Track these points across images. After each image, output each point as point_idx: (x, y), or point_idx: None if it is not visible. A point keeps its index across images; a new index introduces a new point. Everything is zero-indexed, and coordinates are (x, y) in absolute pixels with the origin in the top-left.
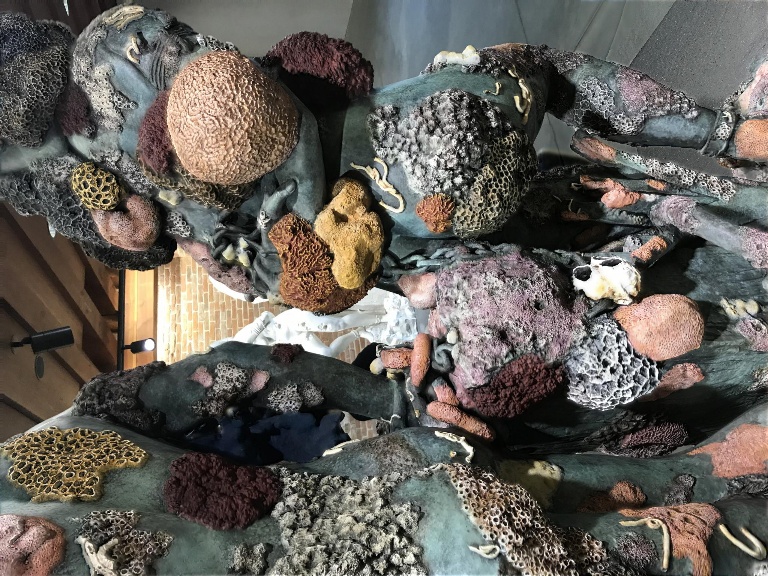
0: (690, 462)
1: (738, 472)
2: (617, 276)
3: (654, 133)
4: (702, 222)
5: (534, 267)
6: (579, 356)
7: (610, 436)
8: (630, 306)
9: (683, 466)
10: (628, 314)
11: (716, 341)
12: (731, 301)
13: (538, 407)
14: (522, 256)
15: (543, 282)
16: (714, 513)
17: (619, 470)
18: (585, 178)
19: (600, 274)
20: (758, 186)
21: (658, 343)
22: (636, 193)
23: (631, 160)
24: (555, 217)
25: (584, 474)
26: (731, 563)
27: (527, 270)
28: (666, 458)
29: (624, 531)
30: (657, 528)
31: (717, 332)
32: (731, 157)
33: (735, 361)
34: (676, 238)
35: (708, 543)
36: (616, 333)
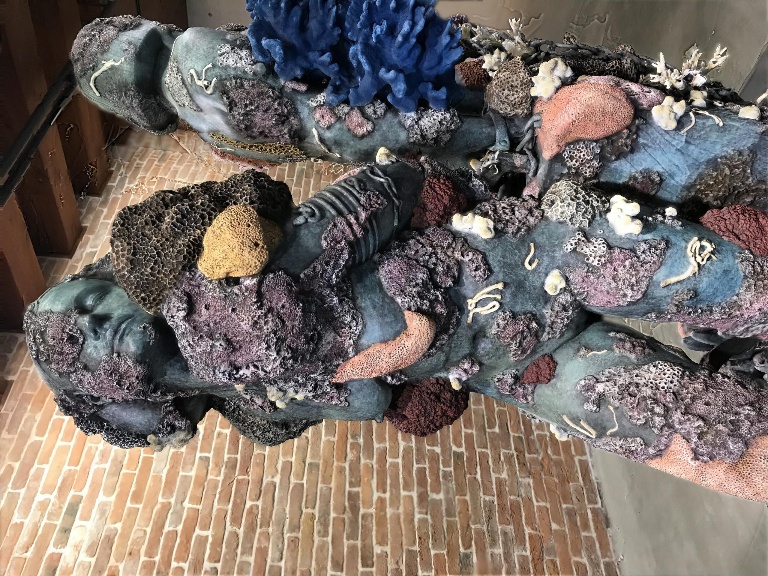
0: None
1: None
2: None
3: None
4: None
5: None
6: None
7: None
8: None
9: None
10: None
11: None
12: None
13: None
14: None
15: None
16: None
17: None
18: None
19: None
20: None
21: None
22: None
23: None
24: None
25: None
26: None
27: None
28: None
29: None
30: None
31: None
32: None
33: None
34: None
35: None
36: None
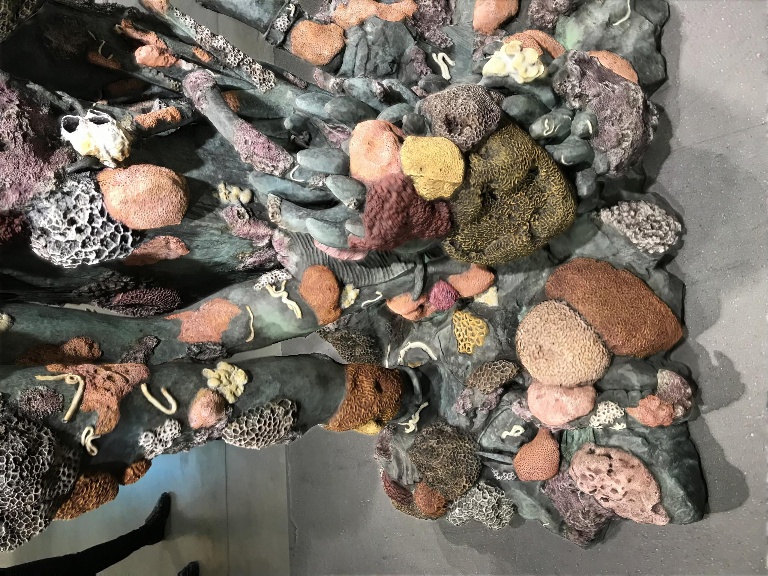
0: (163, 325)
1: (199, 339)
2: (101, 136)
3: (222, 1)
4: (210, 104)
5: (13, 102)
6: (44, 209)
7: (99, 292)
8: (115, 170)
9: (154, 328)
10: (110, 177)
11: (198, 221)
12: (229, 187)
13: (2, 254)
14: (8, 87)
15: (13, 121)
16: (142, 373)
17: (82, 326)
18: (127, 23)
19: (88, 129)
20: (296, 86)
21: (133, 212)
22: (173, 56)
23: (182, 20)
24: (84, 55)
25: (38, 326)
26: (139, 417)
27: (1, 103)
28: (142, 319)
29: (35, 385)
30: (74, 384)
31: (203, 213)
32: (289, 51)
33: (220, 242)
34: (196, 114)
35: (122, 399)
36: (91, 194)
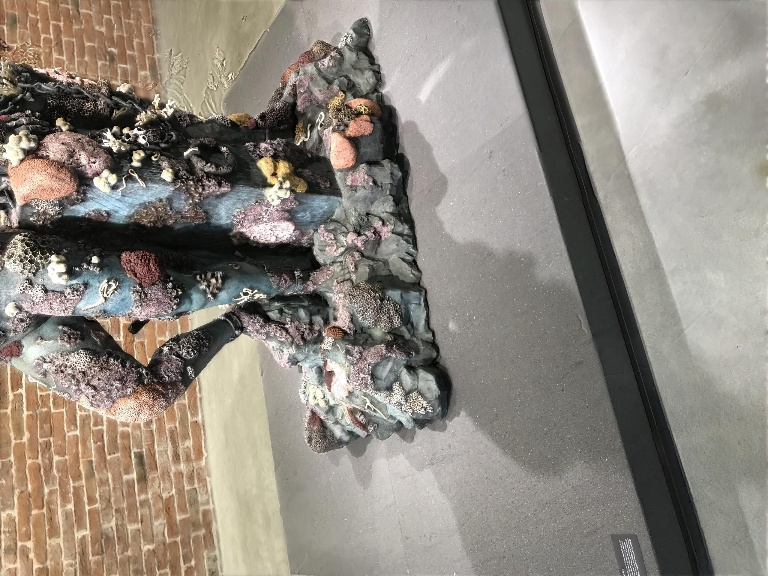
0: None
1: None
2: None
3: None
4: None
5: None
6: None
7: None
8: None
9: None
10: None
11: None
12: None
13: None
14: None
15: None
16: None
17: None
18: None
19: None
20: None
21: None
22: None
23: None
24: None
25: None
26: None
27: None
28: None
29: None
30: None
31: None
32: None
33: None
34: None
35: None
36: None
